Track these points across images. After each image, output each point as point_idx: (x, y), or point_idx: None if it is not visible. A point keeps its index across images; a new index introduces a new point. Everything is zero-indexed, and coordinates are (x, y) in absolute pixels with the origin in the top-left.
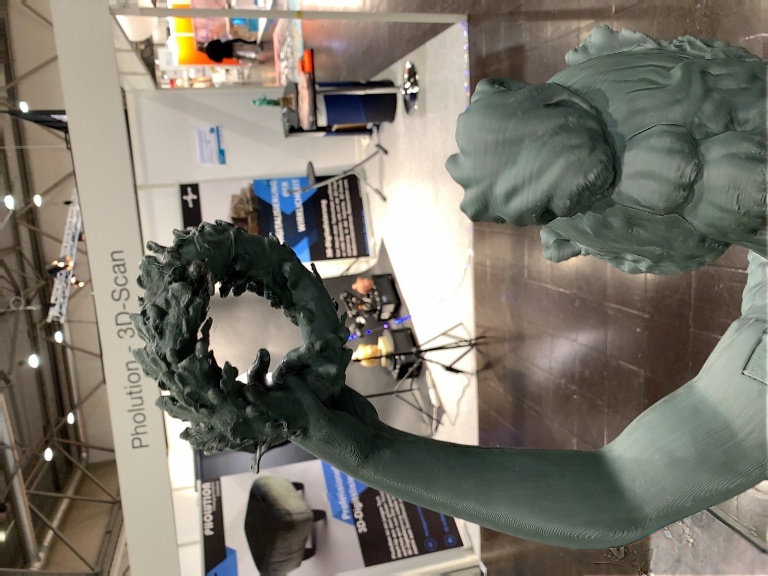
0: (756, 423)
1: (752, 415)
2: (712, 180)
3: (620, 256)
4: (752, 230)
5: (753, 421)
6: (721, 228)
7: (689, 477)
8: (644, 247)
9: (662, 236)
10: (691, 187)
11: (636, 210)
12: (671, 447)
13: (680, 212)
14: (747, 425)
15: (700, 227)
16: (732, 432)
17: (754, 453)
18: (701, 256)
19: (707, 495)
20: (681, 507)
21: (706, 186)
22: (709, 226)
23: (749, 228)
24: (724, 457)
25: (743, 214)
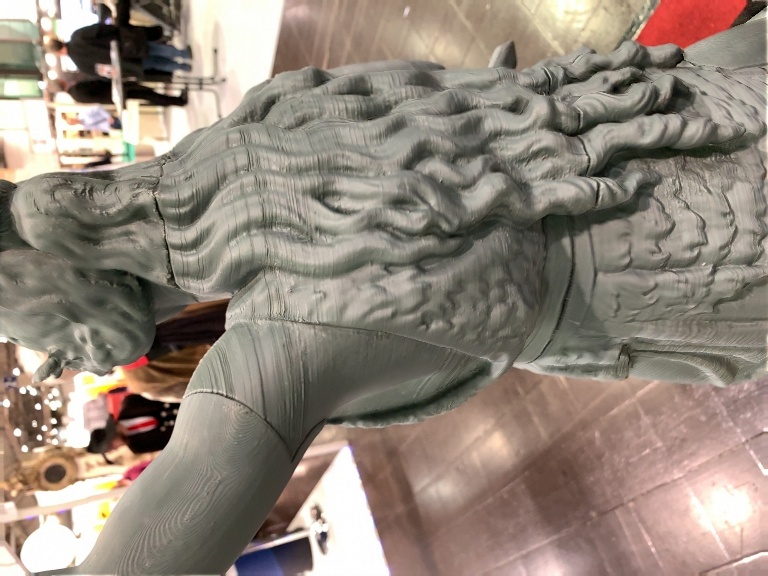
0: (188, 432)
1: (185, 427)
2: (18, 199)
3: (78, 345)
4: (80, 236)
5: (186, 432)
6: (44, 235)
7: (136, 524)
8: (41, 299)
9: (40, 278)
10: (6, 210)
11: (3, 258)
12: (123, 501)
13: (22, 240)
14: (183, 440)
15: (35, 243)
16: (174, 455)
17: (194, 466)
18: (107, 301)
19: (165, 543)
20: (141, 573)
21: (17, 206)
22: (37, 238)
23: (71, 232)
24: (168, 484)
25: (45, 214)
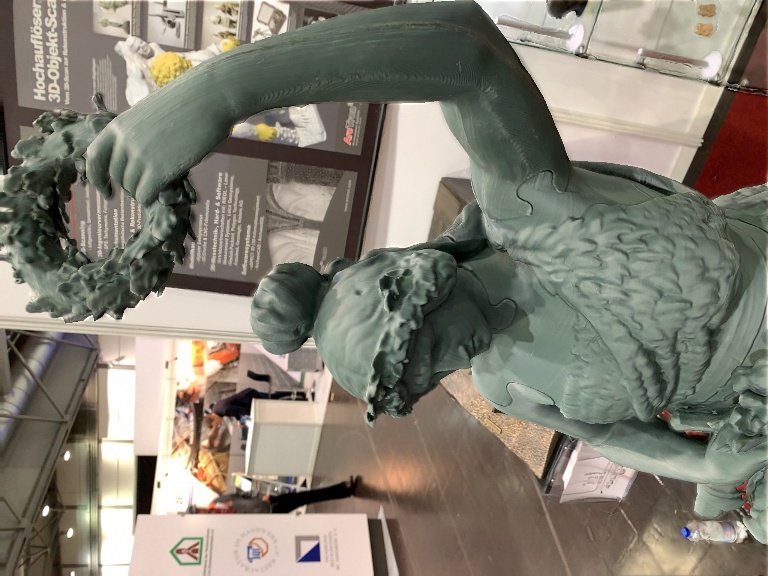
0: None
1: None
2: None
3: None
4: None
5: None
6: None
7: None
8: None
9: None
10: None
11: None
12: None
13: None
14: None
15: None
16: None
17: None
18: None
19: None
20: None
21: None
22: None
23: None
24: None
25: None
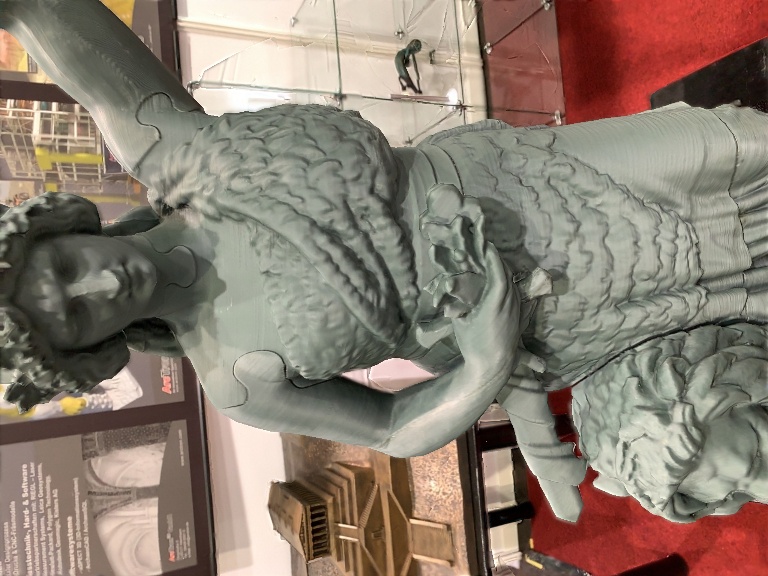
0: None
1: None
2: None
3: None
4: None
5: None
6: None
7: None
8: None
9: None
10: None
11: None
12: None
13: None
14: None
15: None
16: None
17: None
18: None
19: None
20: None
21: None
22: None
23: None
24: None
25: None
